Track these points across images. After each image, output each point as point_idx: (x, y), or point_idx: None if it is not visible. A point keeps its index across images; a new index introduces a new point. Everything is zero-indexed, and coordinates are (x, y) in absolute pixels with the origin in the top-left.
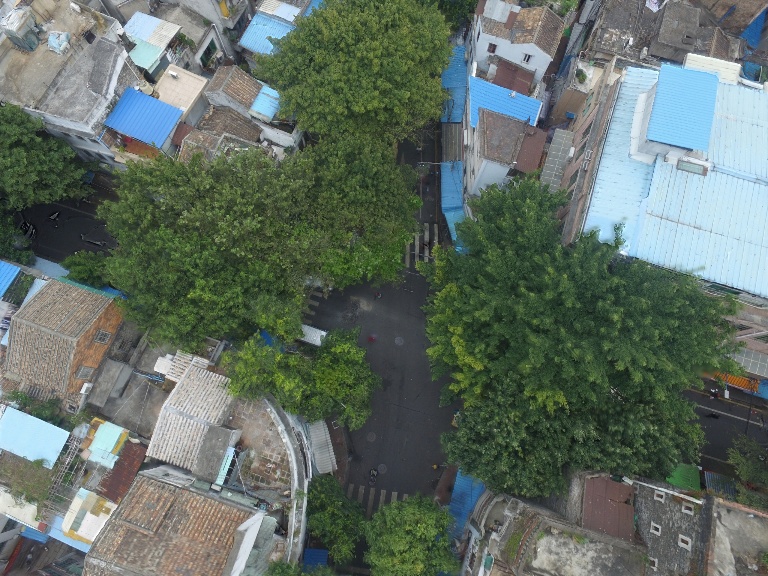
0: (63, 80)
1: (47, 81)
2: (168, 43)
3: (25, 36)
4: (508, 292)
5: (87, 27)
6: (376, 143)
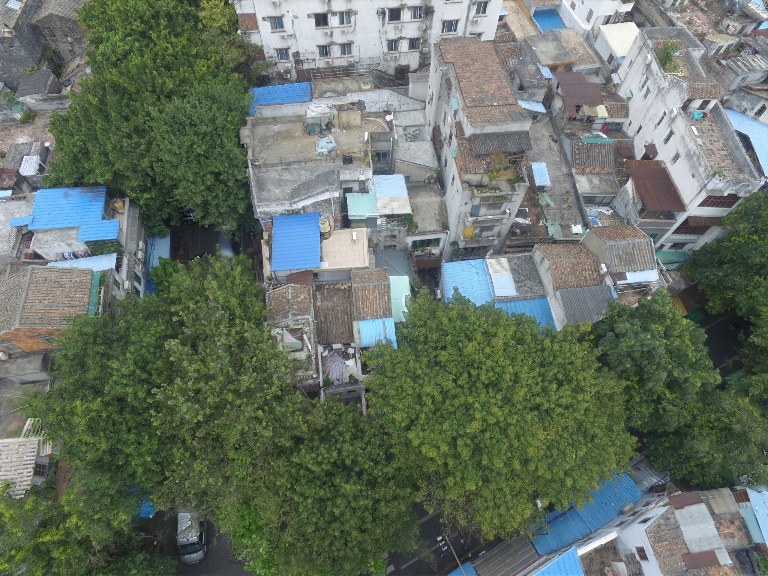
0: (297, 167)
1: (287, 159)
2: (387, 214)
3: (312, 124)
4: None
5: (354, 154)
6: (389, 483)
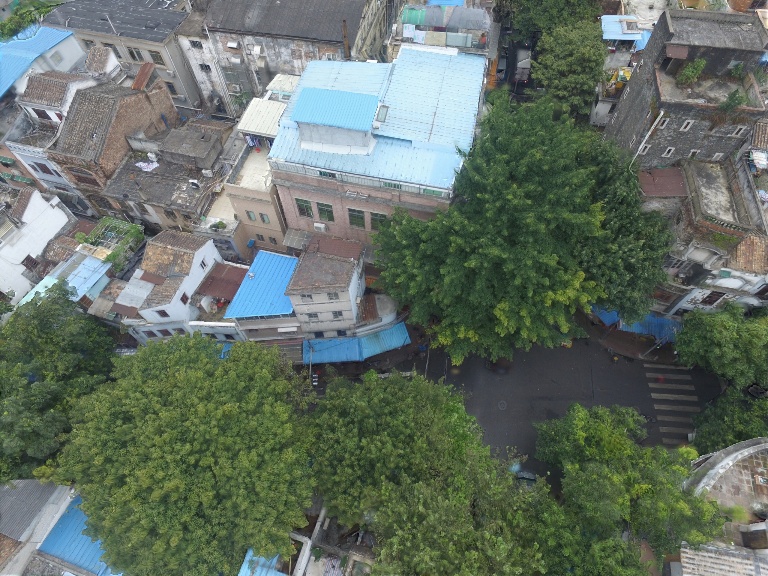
0: None
1: None
2: None
3: None
4: (510, 249)
5: None
6: None
